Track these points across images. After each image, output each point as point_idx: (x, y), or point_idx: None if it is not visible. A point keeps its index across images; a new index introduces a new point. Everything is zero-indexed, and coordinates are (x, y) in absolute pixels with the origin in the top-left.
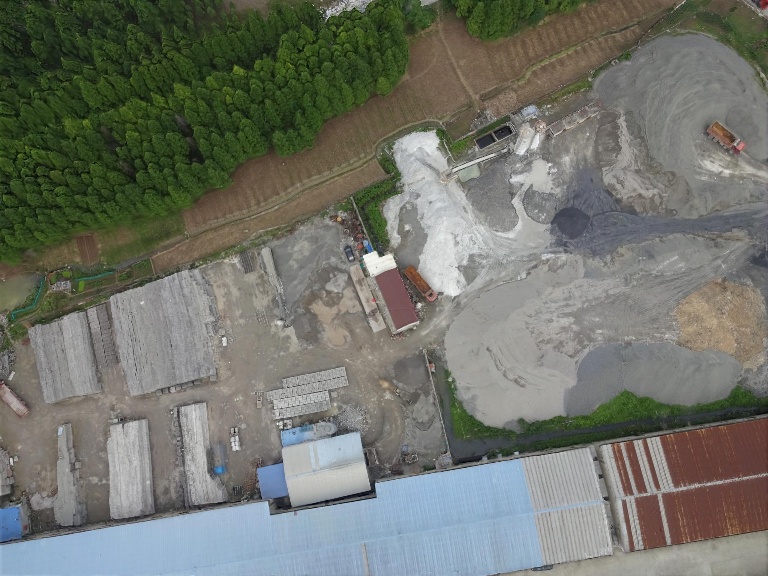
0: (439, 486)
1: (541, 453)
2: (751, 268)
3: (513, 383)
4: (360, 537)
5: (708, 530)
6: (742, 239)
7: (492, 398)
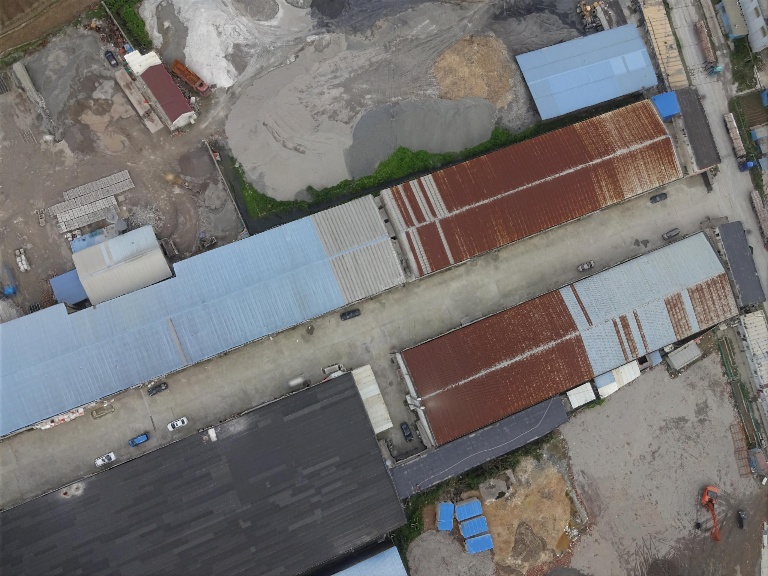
0: (236, 254)
1: (329, 208)
2: (493, 23)
3: (293, 151)
4: (165, 314)
5: (483, 244)
6: (483, 0)
7: (277, 170)
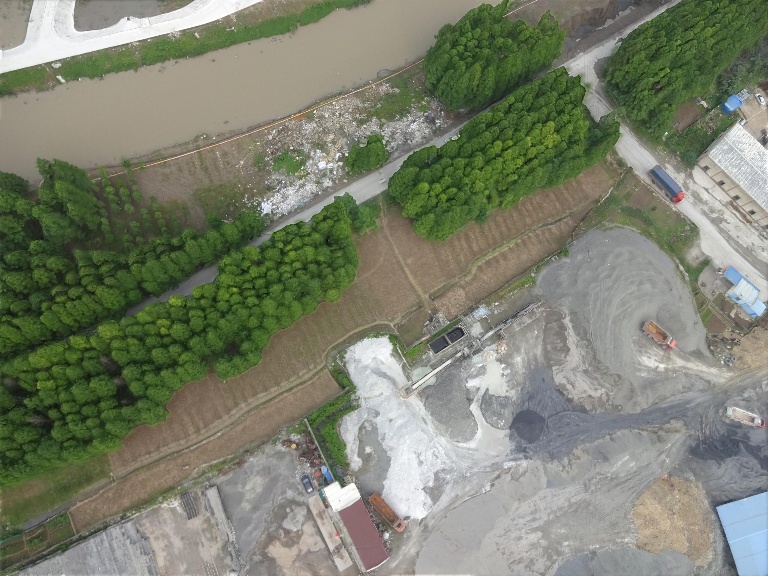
0: None
1: None
2: (691, 460)
3: None
4: None
5: None
6: (680, 430)
7: None
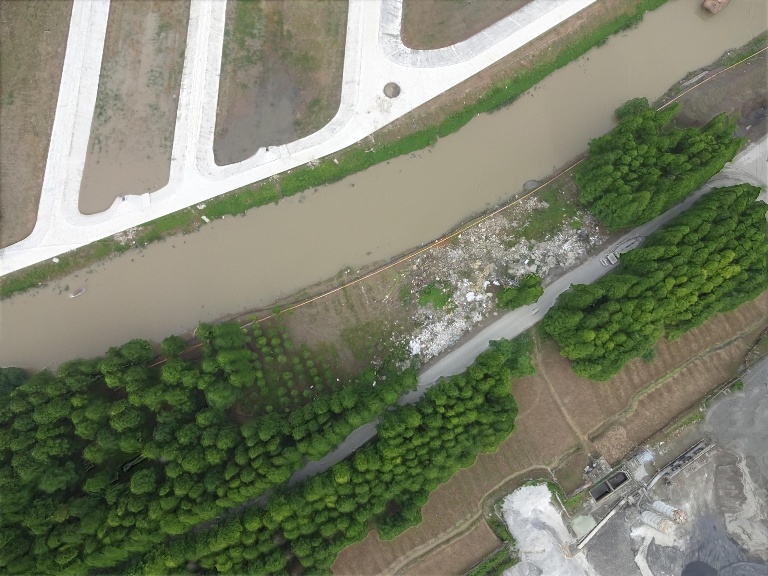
0: None
1: None
2: None
3: None
4: None
5: None
6: None
7: None
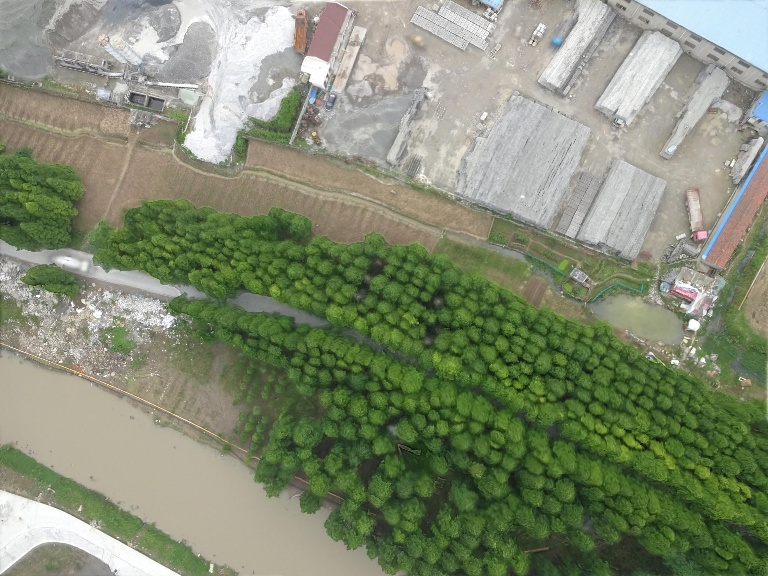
0: None
1: None
2: None
3: None
4: None
5: None
6: None
7: None
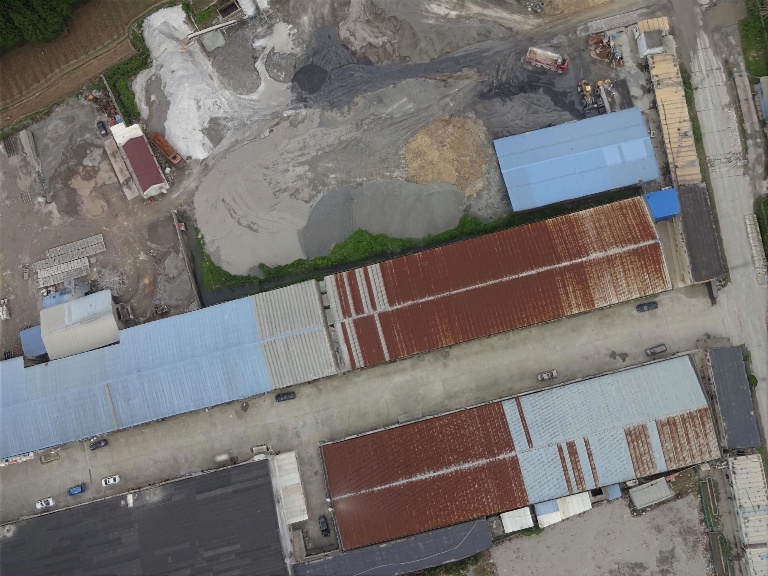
0: (176, 327)
1: None
2: (477, 103)
3: (247, 229)
4: (103, 378)
5: (423, 343)
6: (471, 77)
7: (231, 246)
